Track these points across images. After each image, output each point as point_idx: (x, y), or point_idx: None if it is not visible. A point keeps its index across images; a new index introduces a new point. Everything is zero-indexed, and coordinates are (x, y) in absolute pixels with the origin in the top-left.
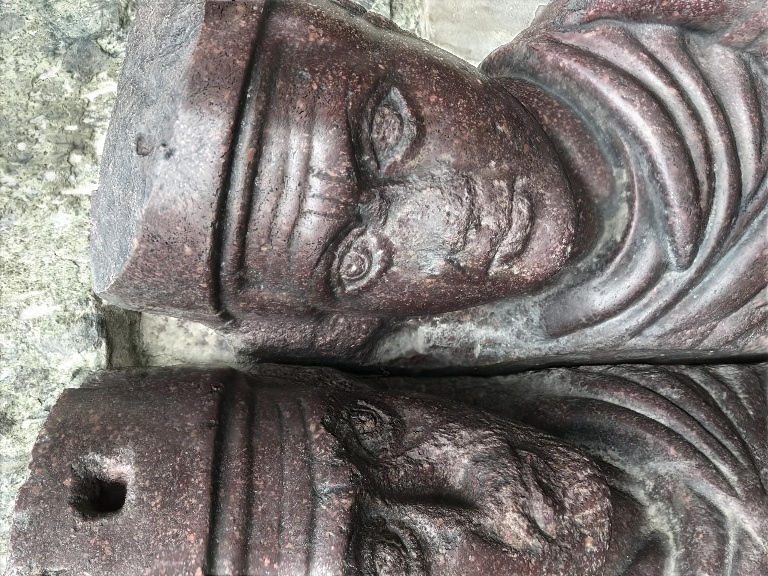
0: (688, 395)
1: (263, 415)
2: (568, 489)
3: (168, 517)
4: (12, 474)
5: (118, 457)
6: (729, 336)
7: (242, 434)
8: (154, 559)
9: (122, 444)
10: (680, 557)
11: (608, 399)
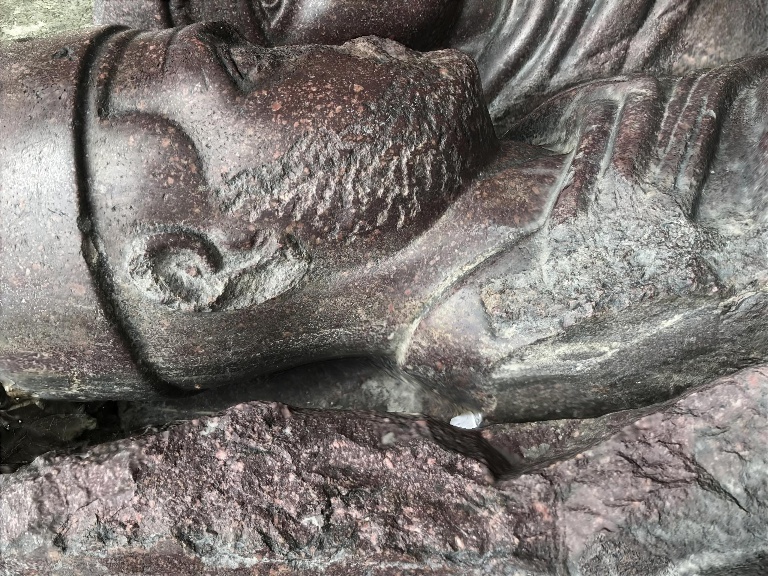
0: None
1: None
2: None
3: None
4: None
5: None
6: (644, 52)
7: None
8: None
9: None
10: None
11: None
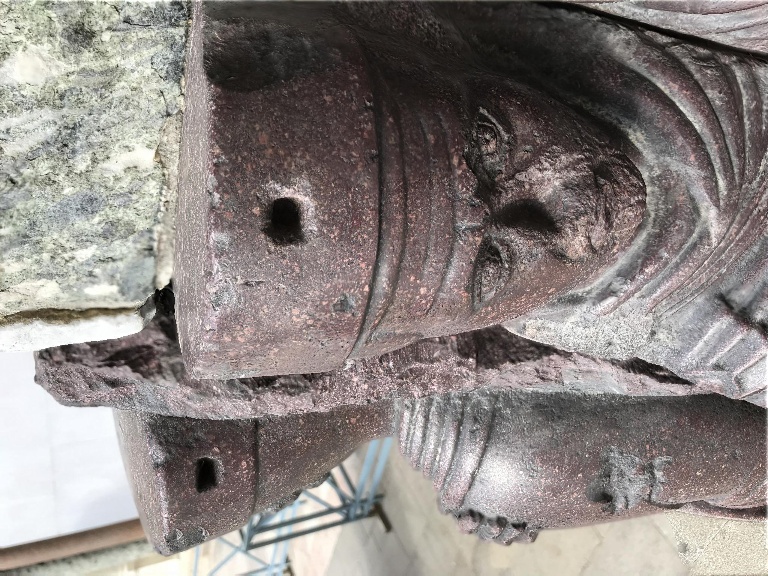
0: (729, 104)
1: (411, 138)
2: (620, 212)
3: (345, 248)
4: (100, 89)
5: (296, 187)
6: None
7: (398, 165)
8: (333, 278)
9: (298, 174)
10: (652, 234)
11: (661, 85)
